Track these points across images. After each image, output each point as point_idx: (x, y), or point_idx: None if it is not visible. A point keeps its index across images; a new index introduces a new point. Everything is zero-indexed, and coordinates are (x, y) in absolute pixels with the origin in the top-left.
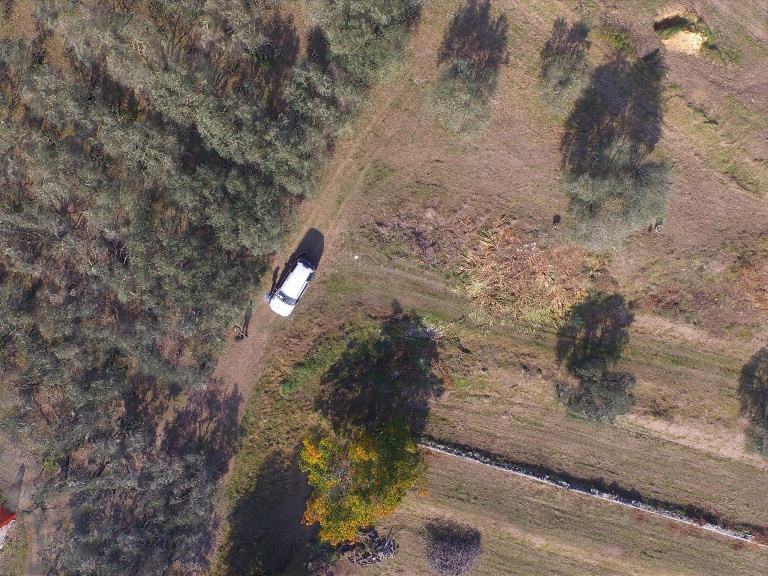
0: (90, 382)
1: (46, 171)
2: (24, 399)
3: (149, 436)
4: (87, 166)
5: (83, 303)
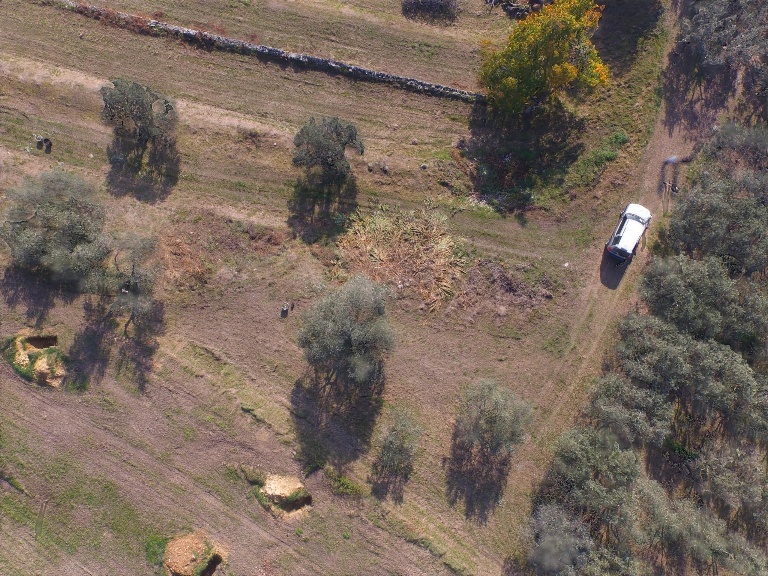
0: None
1: None
2: None
3: (749, 83)
4: None
5: None
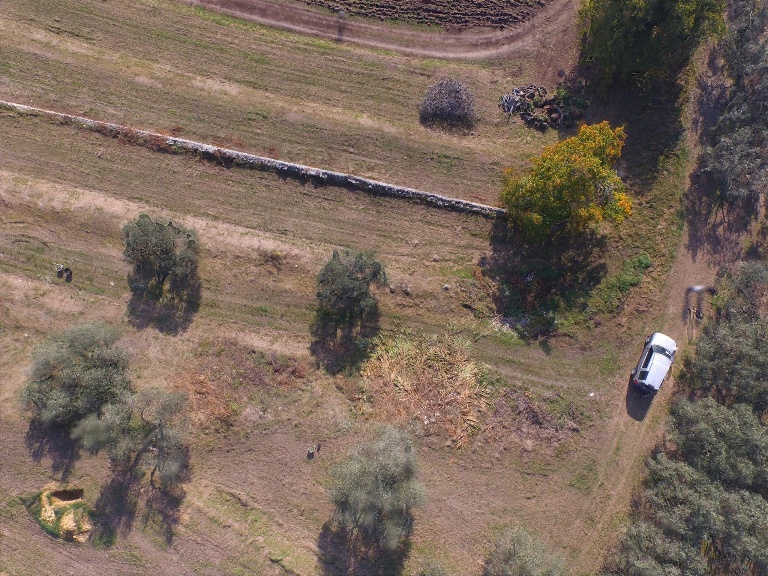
0: None
1: None
2: None
3: None
4: None
5: None
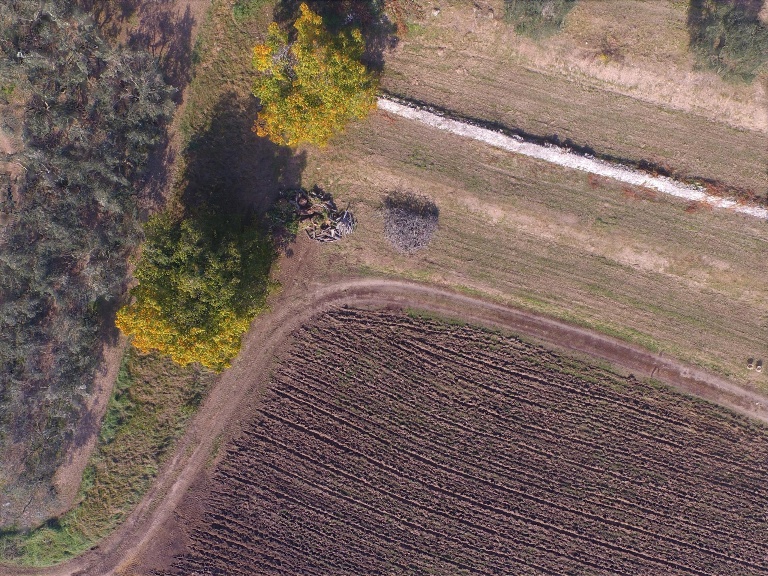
0: (43, 3)
1: None
2: None
3: None
4: None
5: None
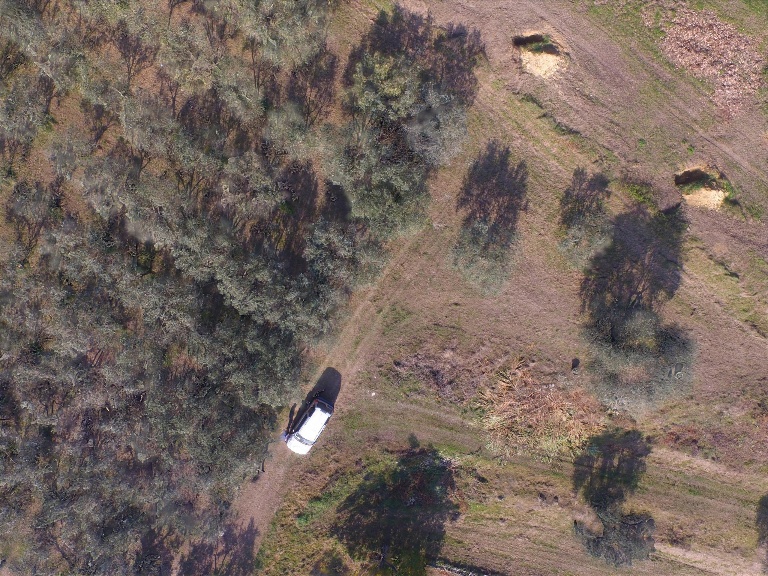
0: None
1: (65, 331)
2: (39, 533)
3: (165, 569)
4: (104, 306)
5: (99, 439)
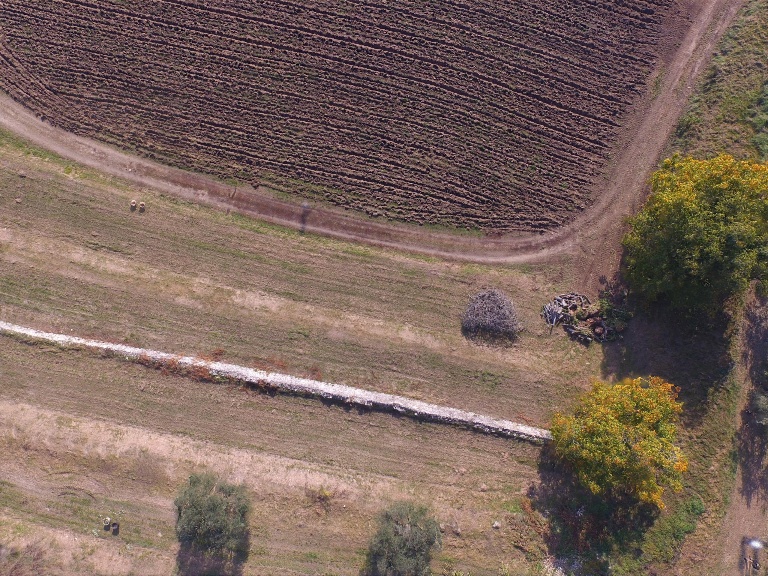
0: None
1: None
2: None
3: None
4: None
5: None
